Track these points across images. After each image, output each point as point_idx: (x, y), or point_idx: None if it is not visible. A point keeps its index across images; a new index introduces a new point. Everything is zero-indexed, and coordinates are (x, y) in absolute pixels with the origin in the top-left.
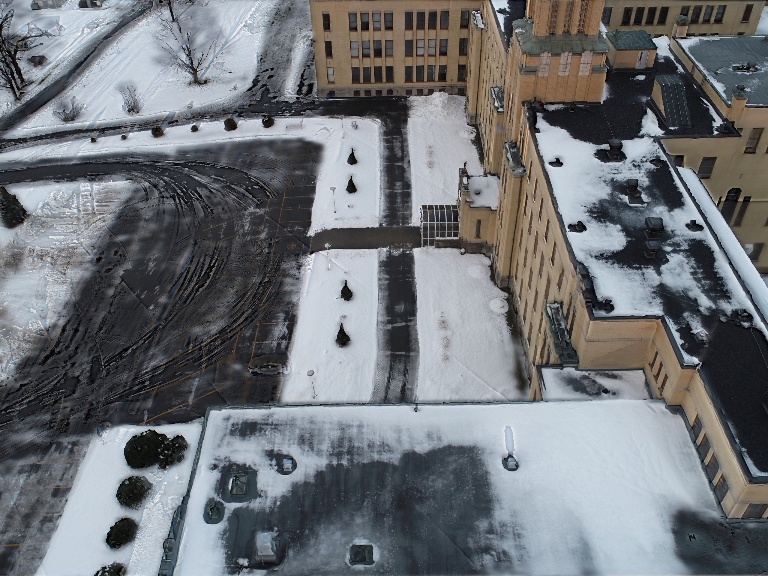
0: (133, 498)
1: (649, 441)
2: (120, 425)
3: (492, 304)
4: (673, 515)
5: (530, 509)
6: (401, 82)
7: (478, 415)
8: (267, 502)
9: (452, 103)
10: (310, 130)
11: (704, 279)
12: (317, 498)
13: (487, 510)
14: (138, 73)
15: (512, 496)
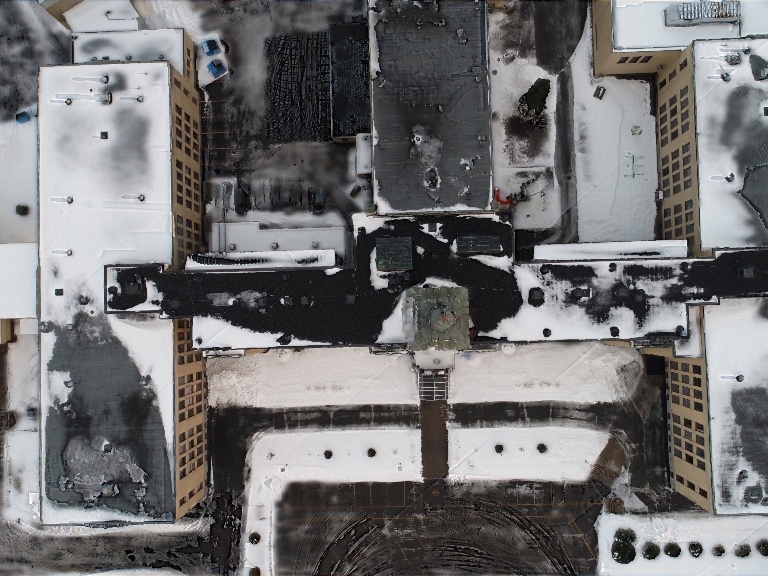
0: (659, 550)
1: (728, 318)
2: (598, 573)
3: (509, 353)
4: (762, 317)
5: (762, 373)
6: (202, 416)
7: (715, 390)
8: (762, 480)
9: (234, 367)
10: (267, 497)
11: (657, 276)
12: (759, 460)
13: (763, 390)
14: None
15: (756, 380)
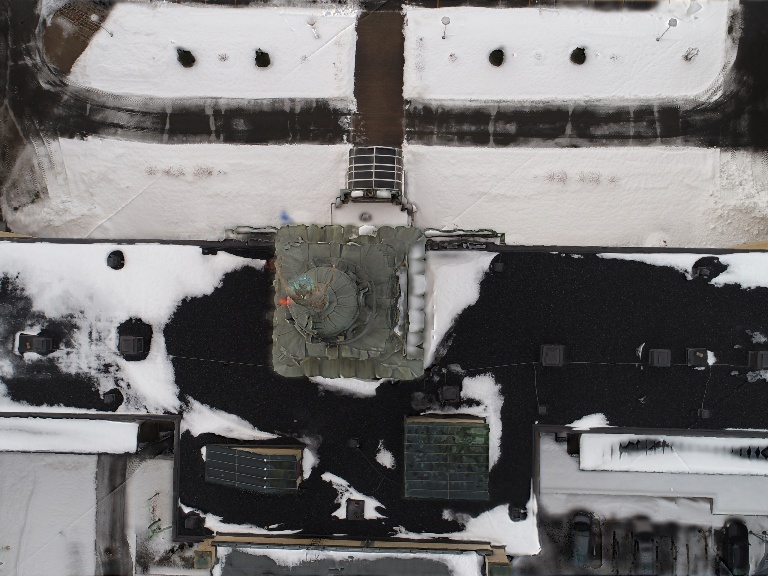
0: None
1: None
2: None
3: None
4: None
5: None
6: None
7: None
8: None
9: (759, 226)
10: None
11: None
12: None
13: None
14: None
15: None
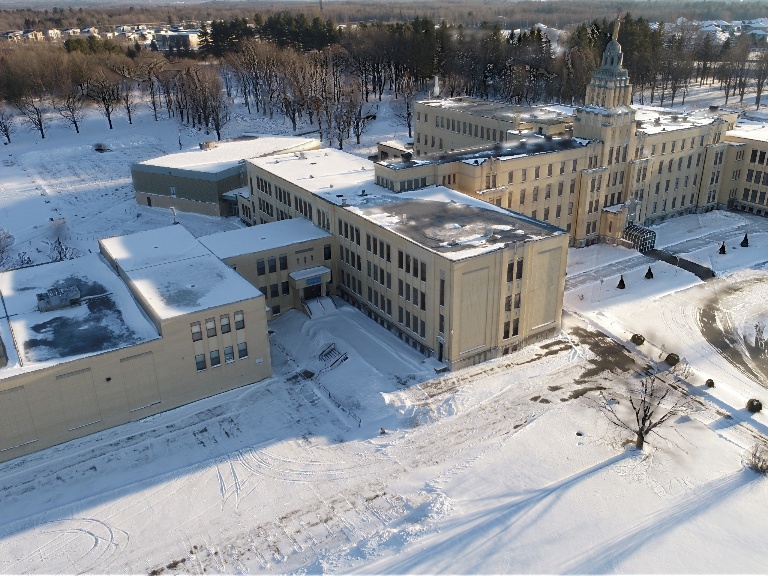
0: None
1: None
2: None
3: (658, 227)
4: None
5: None
6: None
7: None
8: None
9: None
10: None
11: None
12: None
13: None
14: (694, 569)
15: None
